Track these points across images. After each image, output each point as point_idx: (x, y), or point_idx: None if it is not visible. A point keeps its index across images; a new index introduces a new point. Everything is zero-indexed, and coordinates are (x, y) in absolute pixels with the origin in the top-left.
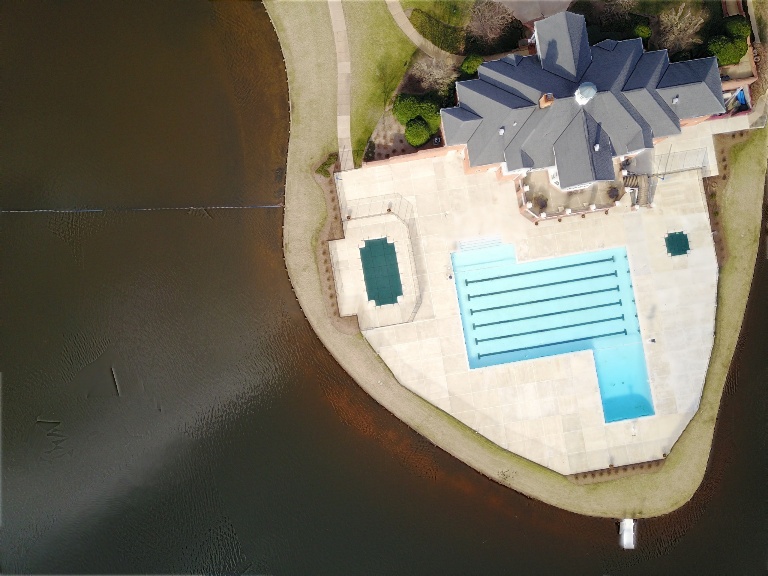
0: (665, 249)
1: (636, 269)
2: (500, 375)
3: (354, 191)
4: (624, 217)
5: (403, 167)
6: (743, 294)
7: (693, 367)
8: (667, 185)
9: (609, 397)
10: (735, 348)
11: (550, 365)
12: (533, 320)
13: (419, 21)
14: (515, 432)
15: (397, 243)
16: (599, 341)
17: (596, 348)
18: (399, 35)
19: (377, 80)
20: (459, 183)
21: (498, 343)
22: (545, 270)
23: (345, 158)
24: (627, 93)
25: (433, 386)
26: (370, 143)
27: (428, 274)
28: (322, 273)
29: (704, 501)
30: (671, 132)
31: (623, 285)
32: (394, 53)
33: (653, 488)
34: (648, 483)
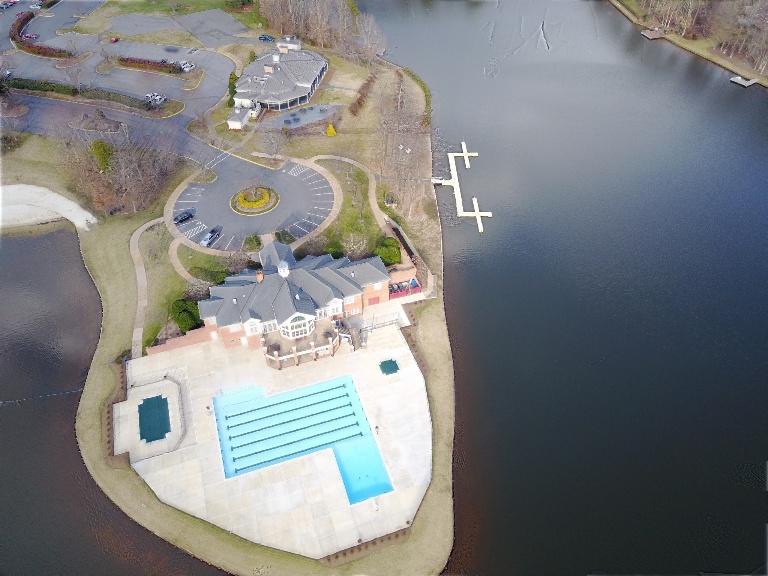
0: (381, 372)
1: (360, 387)
2: (253, 480)
3: (140, 370)
4: (346, 357)
5: (179, 351)
6: (449, 393)
7: (420, 448)
8: (375, 335)
9: (357, 489)
10: (454, 432)
11: (297, 465)
12: (283, 436)
13: (194, 271)
14: (267, 526)
15: (170, 397)
16: (340, 444)
17: (336, 447)
18: (180, 280)
19: (164, 305)
20: (221, 354)
21: (253, 458)
22: (290, 400)
23: (136, 351)
24: (316, 271)
25: (191, 498)
26: (155, 340)
27: (193, 414)
28: (104, 426)
29: (463, 570)
30: (356, 292)
31: (354, 401)
32: (176, 289)
33: (406, 559)
34: (399, 554)
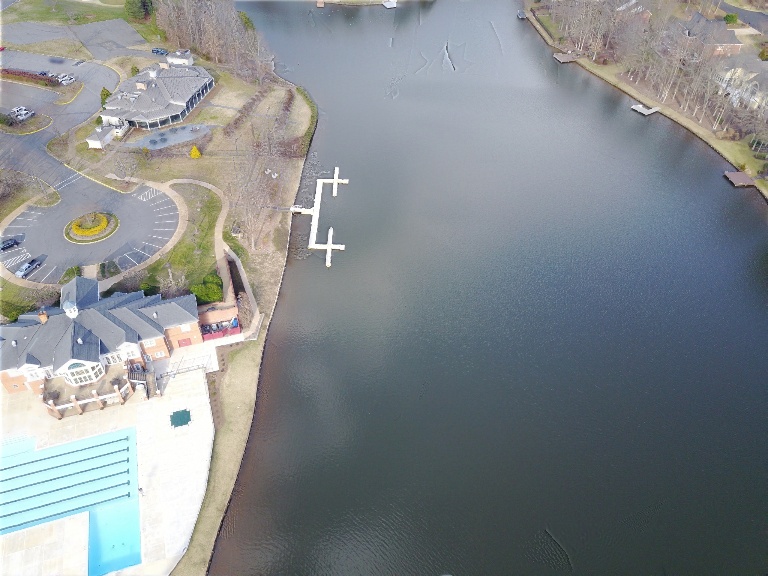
0: (170, 423)
1: (142, 441)
2: None
3: None
4: (138, 406)
5: None
6: (239, 449)
7: (185, 513)
8: (177, 381)
9: (106, 560)
10: (231, 494)
11: (43, 531)
12: (41, 497)
13: None
14: None
15: None
16: (102, 506)
17: (94, 510)
18: None
19: None
20: (2, 400)
21: (0, 522)
22: (63, 454)
23: None
24: (112, 311)
25: None
26: None
27: None
28: None
29: None
30: (155, 335)
31: (132, 457)
32: None
33: None
34: None
